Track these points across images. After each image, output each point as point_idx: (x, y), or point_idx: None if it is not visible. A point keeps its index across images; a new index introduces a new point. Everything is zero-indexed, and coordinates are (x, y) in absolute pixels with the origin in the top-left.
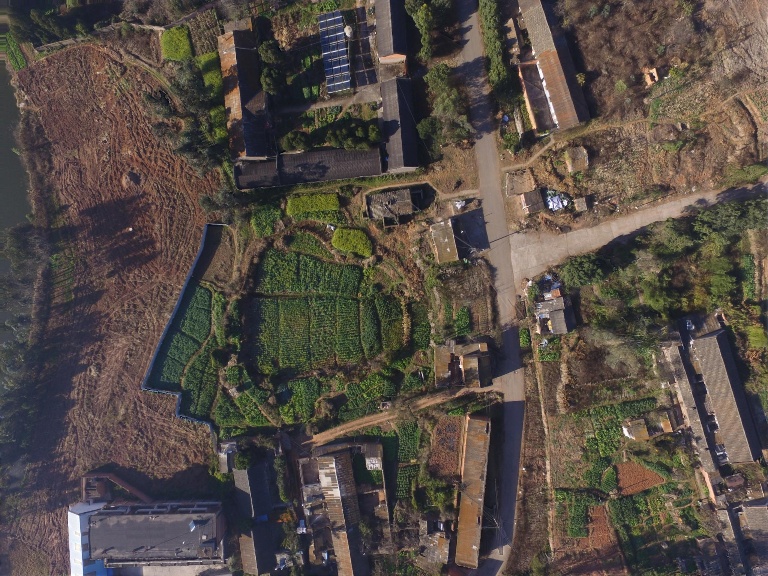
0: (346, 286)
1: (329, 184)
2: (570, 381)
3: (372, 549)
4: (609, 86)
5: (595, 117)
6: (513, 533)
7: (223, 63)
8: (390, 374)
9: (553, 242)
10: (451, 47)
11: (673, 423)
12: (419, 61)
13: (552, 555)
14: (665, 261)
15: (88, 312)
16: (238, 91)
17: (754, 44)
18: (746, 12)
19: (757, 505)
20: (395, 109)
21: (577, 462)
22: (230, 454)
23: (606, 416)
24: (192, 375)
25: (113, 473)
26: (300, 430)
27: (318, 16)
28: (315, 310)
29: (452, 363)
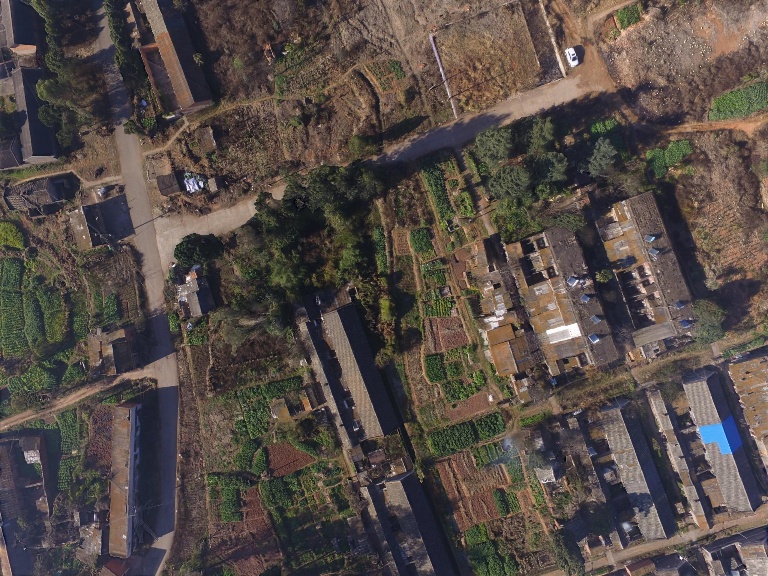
0: (8, 280)
1: None
2: (213, 363)
3: (30, 543)
4: (231, 65)
5: (221, 97)
6: (175, 521)
7: None
8: (53, 366)
9: (195, 224)
10: (84, 35)
11: (313, 401)
12: None
13: (209, 541)
14: (280, 237)
15: None
16: None
17: (369, 15)
18: None
19: (394, 480)
20: (23, 99)
21: (228, 445)
22: None
23: (253, 397)
24: None
25: None
26: None
27: None
28: None
29: None
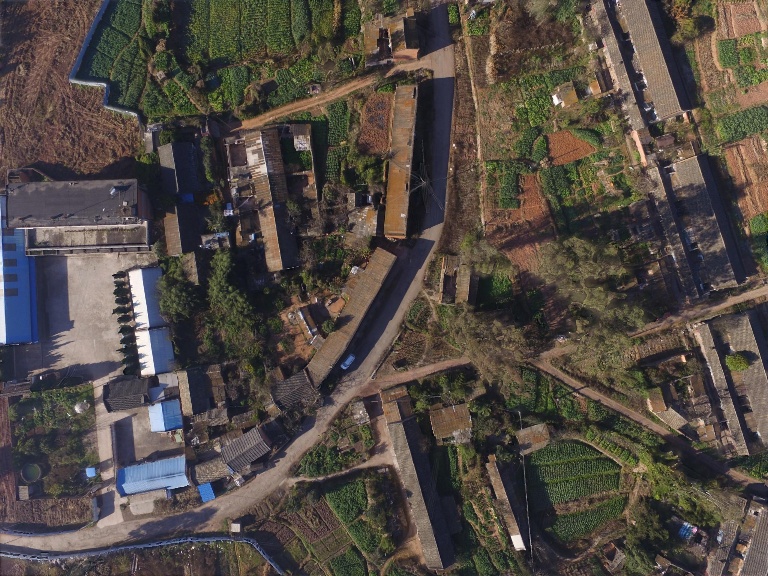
0: None
1: None
2: (498, 49)
3: (299, 226)
4: None
5: None
6: (444, 212)
7: None
8: None
9: None
10: None
11: (601, 84)
12: None
13: (483, 229)
14: None
15: (19, 13)
16: None
17: None
18: None
19: None
20: None
21: (507, 133)
22: (156, 133)
23: (535, 85)
24: (121, 66)
25: (39, 169)
26: (229, 117)
27: None
28: (246, 2)
29: (381, 41)
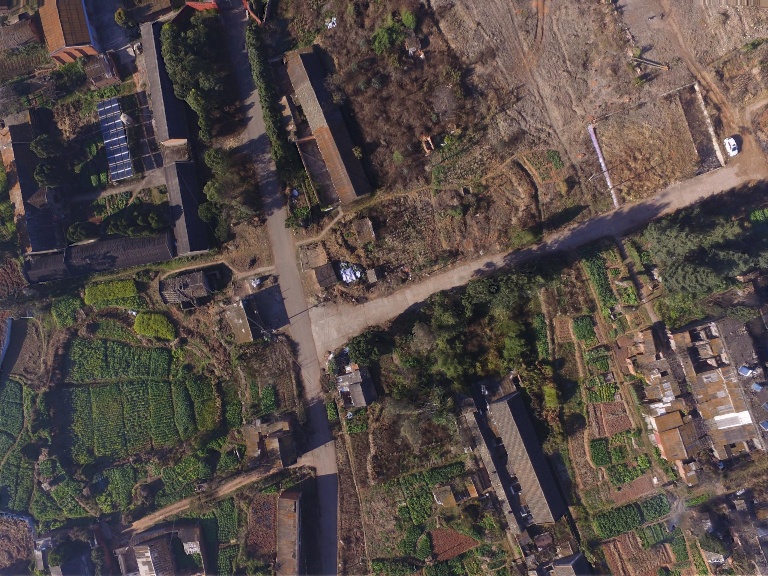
0: (156, 369)
1: (126, 270)
2: (376, 452)
3: None
4: (389, 156)
5: (378, 188)
6: None
7: (4, 158)
8: (206, 455)
9: (351, 313)
10: (234, 126)
11: (478, 487)
12: (203, 142)
13: None
14: (449, 331)
15: None
16: (18, 187)
17: (527, 105)
18: (517, 74)
19: (564, 564)
20: (177, 194)
21: (391, 532)
22: (45, 550)
23: (416, 484)
24: (7, 471)
25: None
26: (119, 518)
27: (97, 104)
28: (127, 395)
29: (262, 441)
